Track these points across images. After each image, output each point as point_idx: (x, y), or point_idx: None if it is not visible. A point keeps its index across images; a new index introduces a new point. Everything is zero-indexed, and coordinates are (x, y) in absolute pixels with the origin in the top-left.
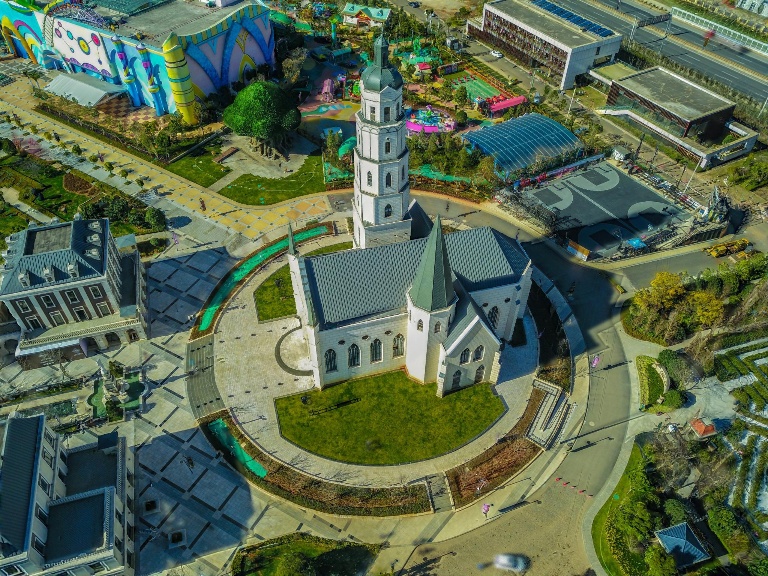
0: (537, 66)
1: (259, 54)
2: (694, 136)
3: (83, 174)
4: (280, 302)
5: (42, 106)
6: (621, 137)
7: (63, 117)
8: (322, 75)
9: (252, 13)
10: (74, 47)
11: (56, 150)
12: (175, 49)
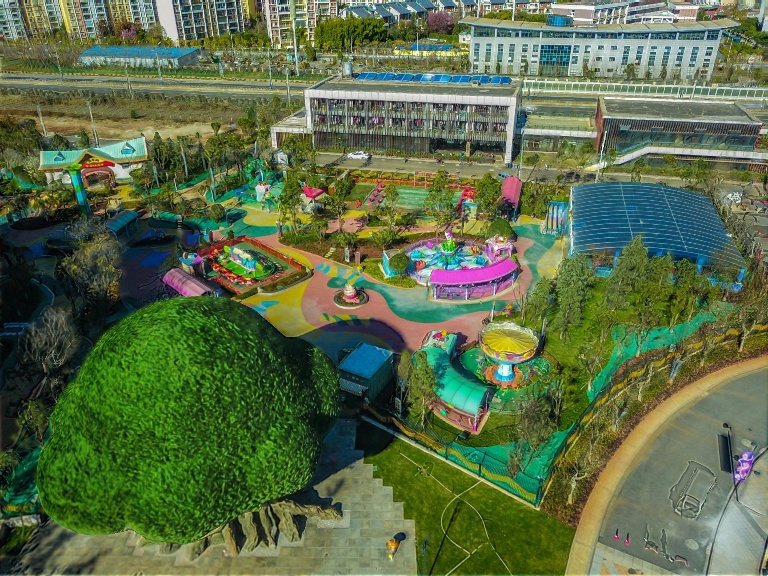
0: (434, 151)
1: None
2: (764, 143)
3: None
4: None
5: None
6: (665, 183)
7: None
8: None
9: None
10: None
11: None
12: None
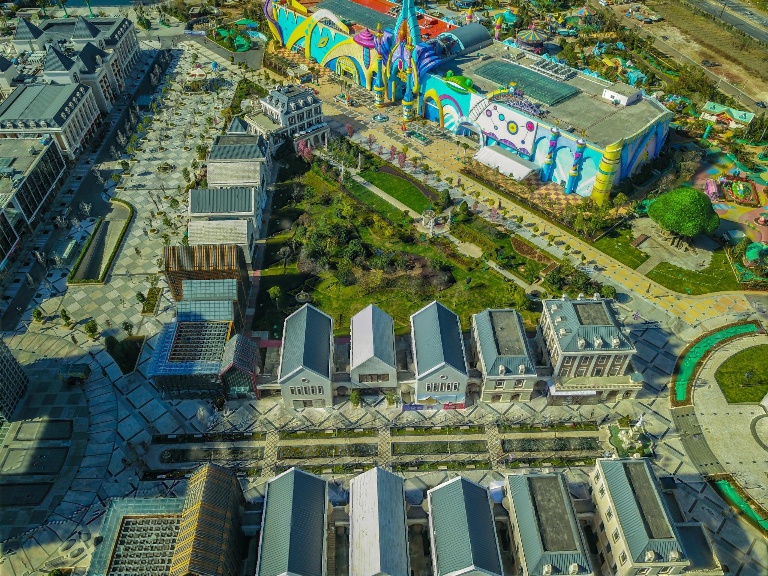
0: None
1: (653, 150)
2: None
3: (527, 240)
4: (740, 389)
5: (467, 170)
6: None
7: (488, 183)
8: (697, 171)
9: (664, 119)
10: (499, 126)
11: (494, 214)
12: (619, 150)
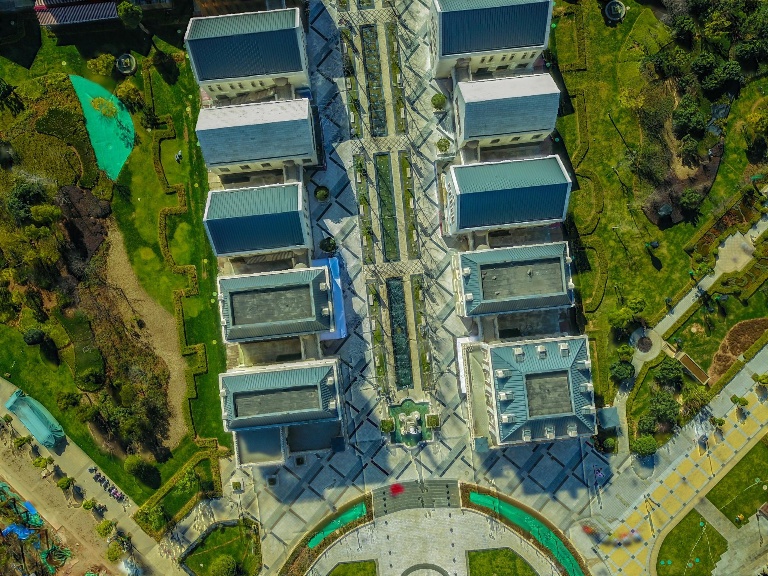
0: None
1: None
2: None
3: (763, 343)
4: (490, 573)
5: None
6: None
7: None
8: None
9: None
10: None
11: None
12: None
